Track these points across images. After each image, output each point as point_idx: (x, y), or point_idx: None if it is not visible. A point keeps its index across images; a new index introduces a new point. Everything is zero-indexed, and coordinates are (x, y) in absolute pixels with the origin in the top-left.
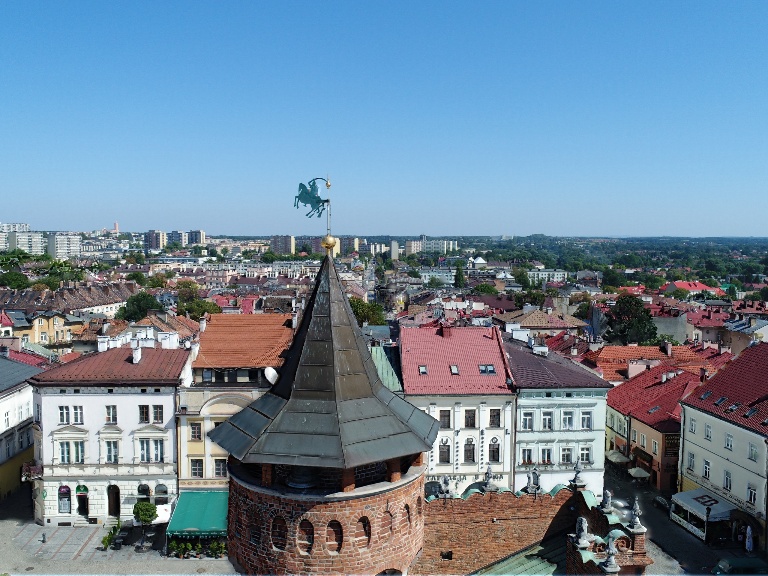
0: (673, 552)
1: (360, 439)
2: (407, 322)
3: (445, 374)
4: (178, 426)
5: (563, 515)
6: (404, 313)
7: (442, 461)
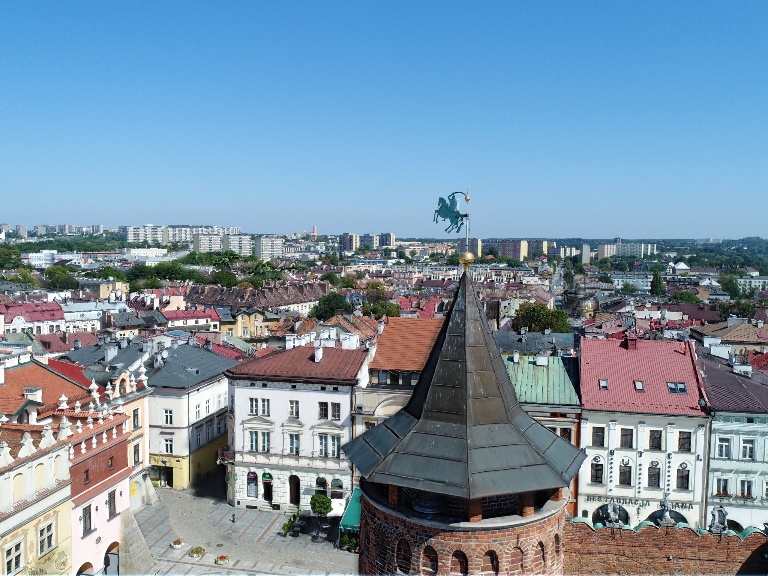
0: None
1: (489, 468)
2: (594, 330)
3: (628, 390)
4: (354, 424)
5: (755, 562)
6: (591, 321)
7: (622, 483)
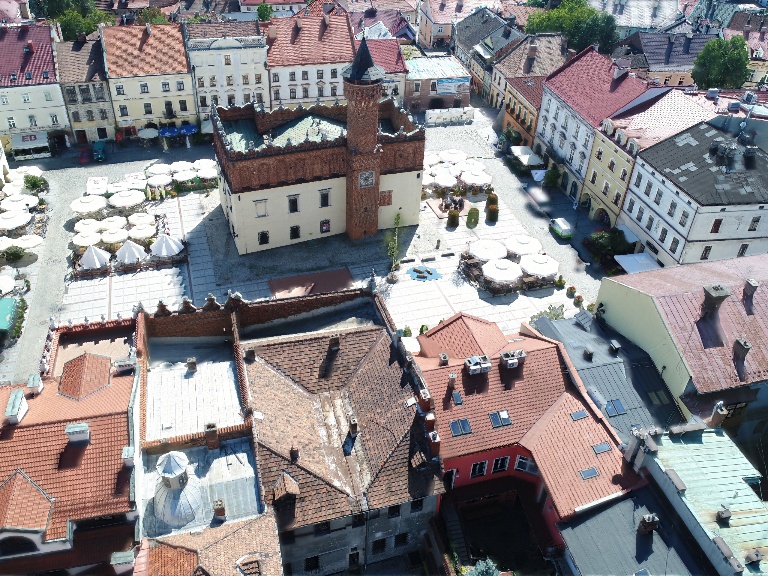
0: (61, 167)
1: None
2: None
3: None
4: None
5: None
6: None
7: None
